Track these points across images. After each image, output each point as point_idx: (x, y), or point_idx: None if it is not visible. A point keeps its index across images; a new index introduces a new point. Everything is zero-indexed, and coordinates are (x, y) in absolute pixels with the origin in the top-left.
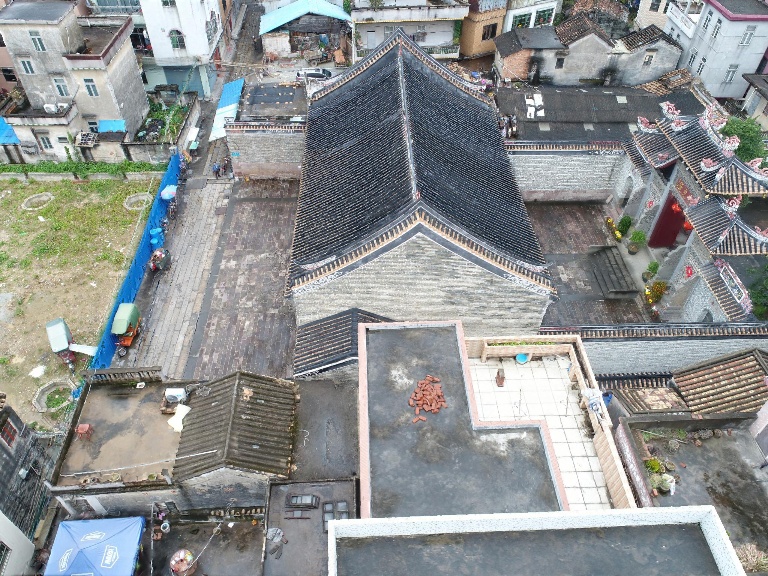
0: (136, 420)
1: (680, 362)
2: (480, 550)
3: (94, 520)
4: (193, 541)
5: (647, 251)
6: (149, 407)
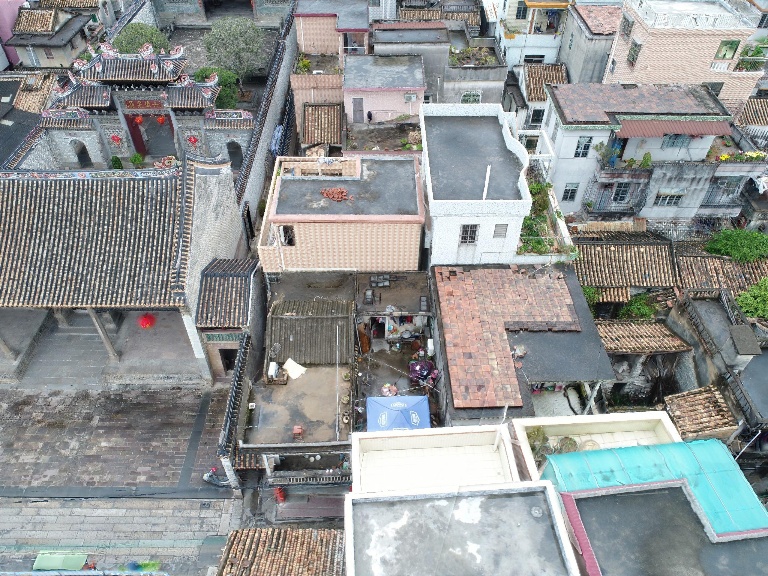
0: (289, 402)
1: (260, 168)
2: (436, 171)
3: (368, 428)
4: (371, 395)
5: (146, 164)
6: (277, 395)
